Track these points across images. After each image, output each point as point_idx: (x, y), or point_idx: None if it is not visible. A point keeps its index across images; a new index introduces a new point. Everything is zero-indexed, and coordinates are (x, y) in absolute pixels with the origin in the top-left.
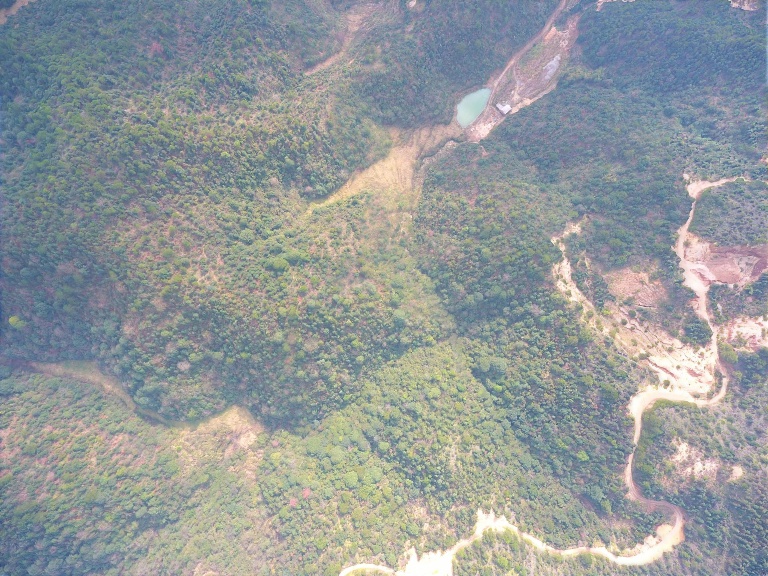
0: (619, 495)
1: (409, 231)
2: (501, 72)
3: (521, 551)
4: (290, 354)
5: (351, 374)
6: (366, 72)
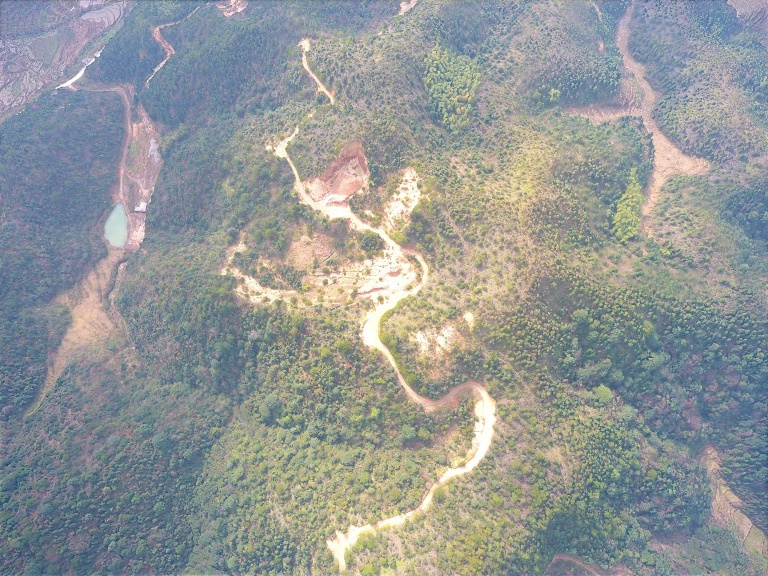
0: (420, 416)
1: (139, 361)
2: (119, 185)
3: (380, 543)
4: (67, 570)
5: (165, 526)
6: None
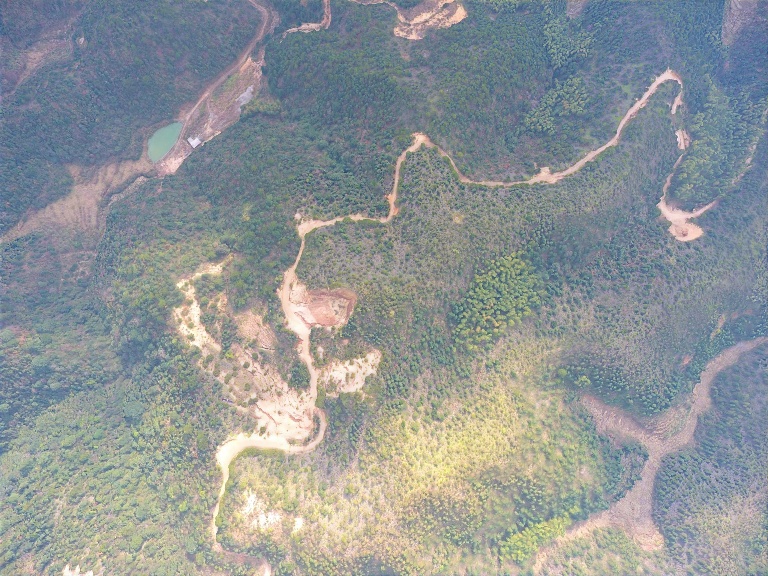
0: (206, 547)
1: (91, 270)
2: (194, 105)
3: None
4: None
5: None
6: (21, 113)
